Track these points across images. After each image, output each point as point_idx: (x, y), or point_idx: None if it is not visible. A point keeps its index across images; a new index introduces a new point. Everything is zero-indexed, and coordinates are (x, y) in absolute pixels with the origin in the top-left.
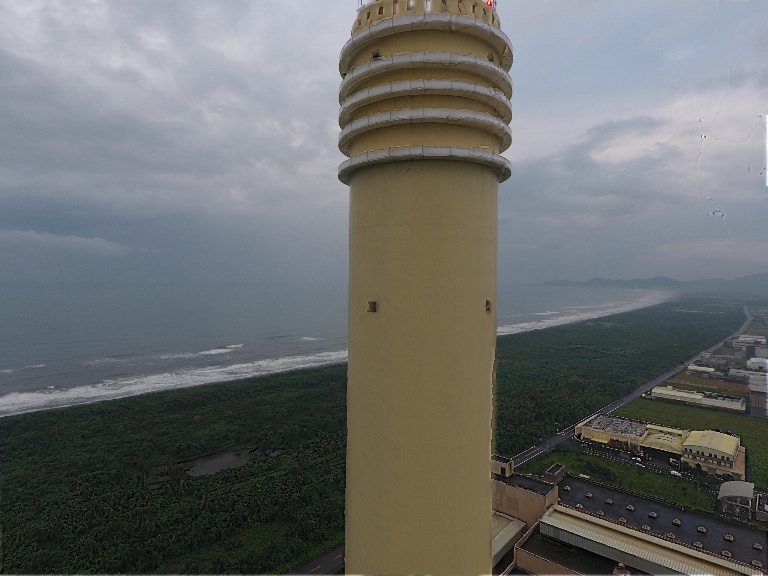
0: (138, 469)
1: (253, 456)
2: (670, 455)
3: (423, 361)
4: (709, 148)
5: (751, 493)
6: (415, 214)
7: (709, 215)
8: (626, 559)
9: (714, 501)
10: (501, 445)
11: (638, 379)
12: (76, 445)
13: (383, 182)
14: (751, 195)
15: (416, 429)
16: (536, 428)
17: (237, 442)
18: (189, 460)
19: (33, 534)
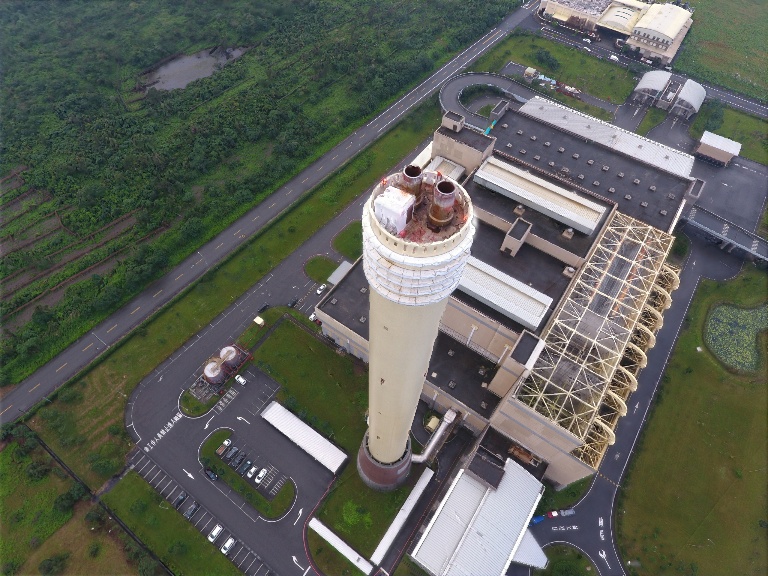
0: (108, 87)
1: (216, 60)
2: (620, 33)
3: (409, 344)
4: None
5: (663, 85)
6: (409, 314)
7: None
8: (525, 202)
9: (632, 89)
10: (462, 34)
11: None
12: (24, 59)
13: None
14: None
15: (404, 356)
16: (502, 3)
17: (192, 41)
18: (153, 69)
19: (61, 168)
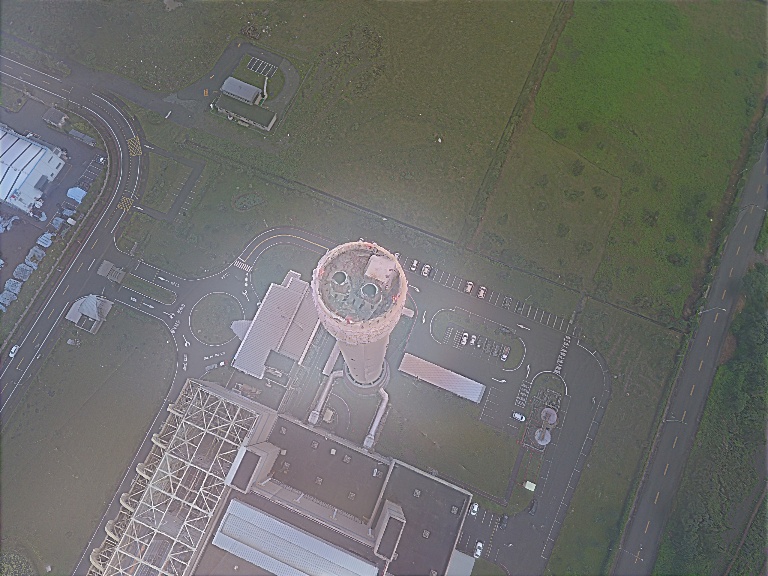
0: None
1: None
2: None
3: None
4: None
5: None
6: None
7: None
8: None
9: None
10: None
11: None
12: None
13: None
14: None
15: None
16: None
17: None
18: None
19: None
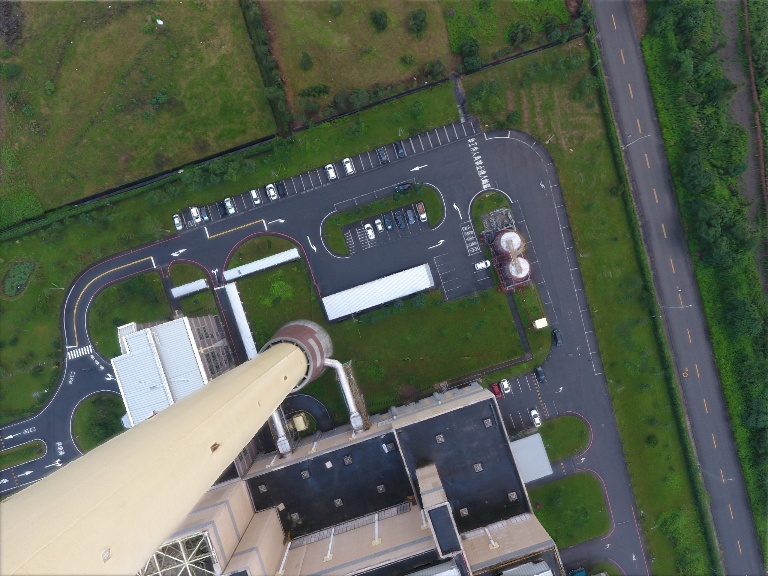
0: None
1: None
2: None
3: None
4: None
5: None
6: None
7: None
8: None
9: None
10: None
11: None
12: None
13: None
14: None
15: None
16: None
17: None
18: None
19: None
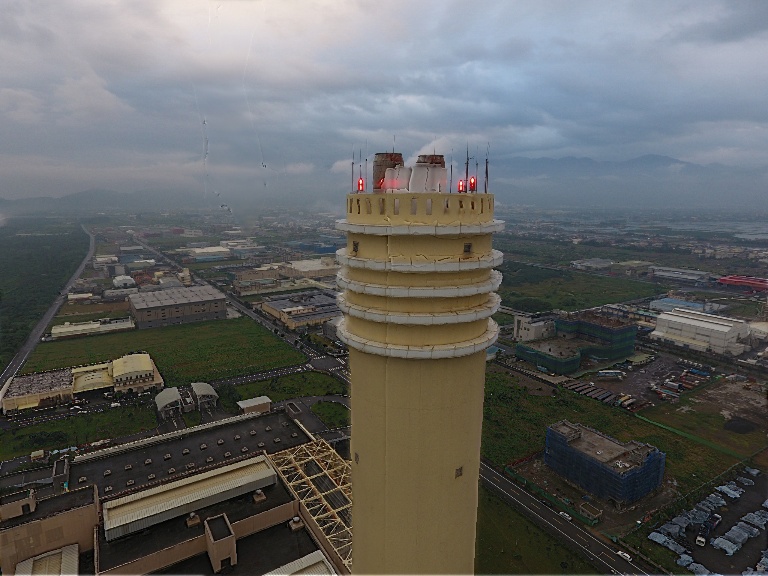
0: None
1: None
2: (101, 390)
3: None
4: (216, 151)
5: (179, 395)
6: None
7: (219, 208)
8: (192, 507)
9: (154, 413)
10: None
11: (27, 323)
12: None
13: (471, 365)
14: (262, 202)
15: None
16: None
17: None
18: None
19: None
